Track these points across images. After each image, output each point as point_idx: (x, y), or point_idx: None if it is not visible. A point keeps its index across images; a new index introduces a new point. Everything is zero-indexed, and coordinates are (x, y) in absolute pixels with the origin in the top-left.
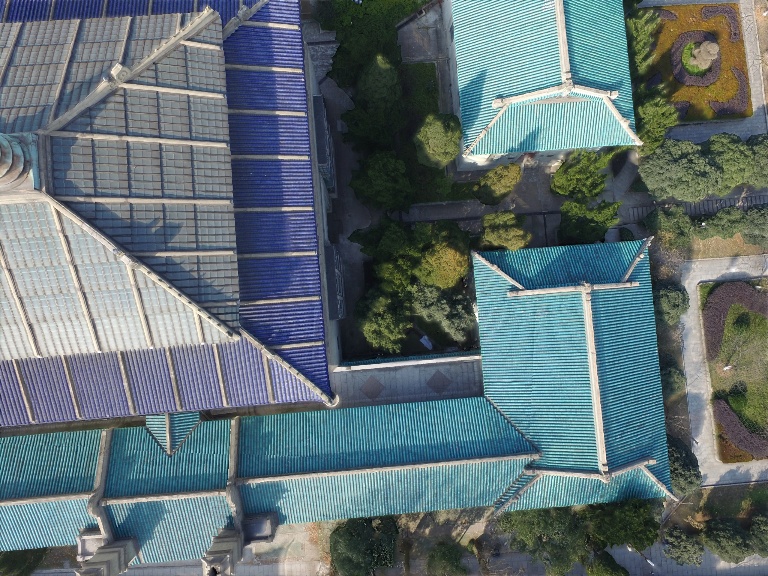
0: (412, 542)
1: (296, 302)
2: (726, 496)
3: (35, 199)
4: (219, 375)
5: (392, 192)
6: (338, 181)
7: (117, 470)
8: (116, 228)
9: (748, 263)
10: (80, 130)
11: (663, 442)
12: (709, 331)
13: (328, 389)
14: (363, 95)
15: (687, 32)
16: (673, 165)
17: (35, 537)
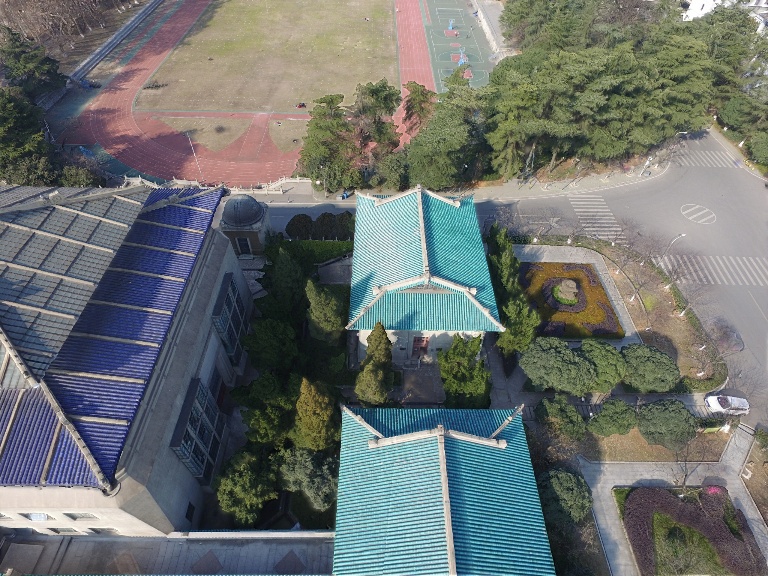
0: None
1: (119, 381)
2: None
3: None
4: (3, 441)
5: (278, 352)
6: (248, 362)
7: None
8: None
9: (663, 470)
10: (3, 220)
11: None
12: (635, 545)
13: (111, 472)
14: (275, 287)
15: (553, 277)
16: (542, 353)
17: None
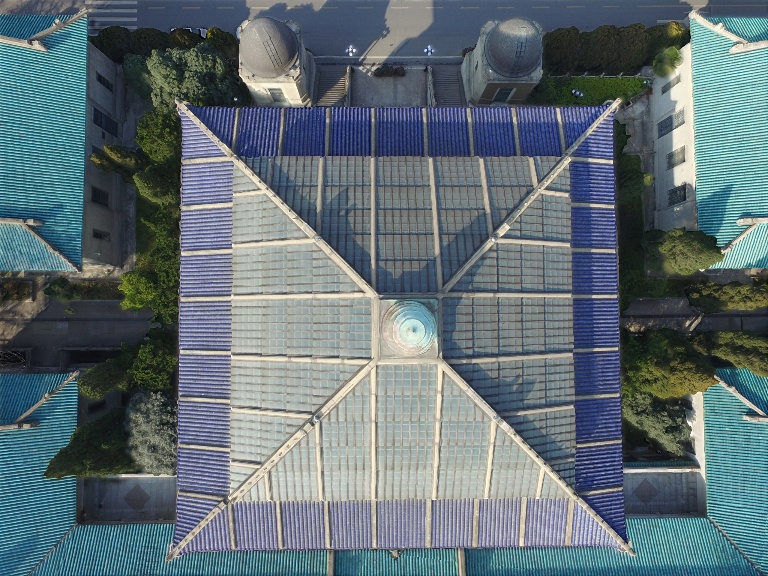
0: None
1: (601, 446)
2: None
3: (427, 362)
4: (523, 517)
5: None
6: None
7: (344, 570)
8: (487, 388)
9: None
10: (464, 289)
11: None
12: None
13: None
14: None
15: None
16: None
17: None
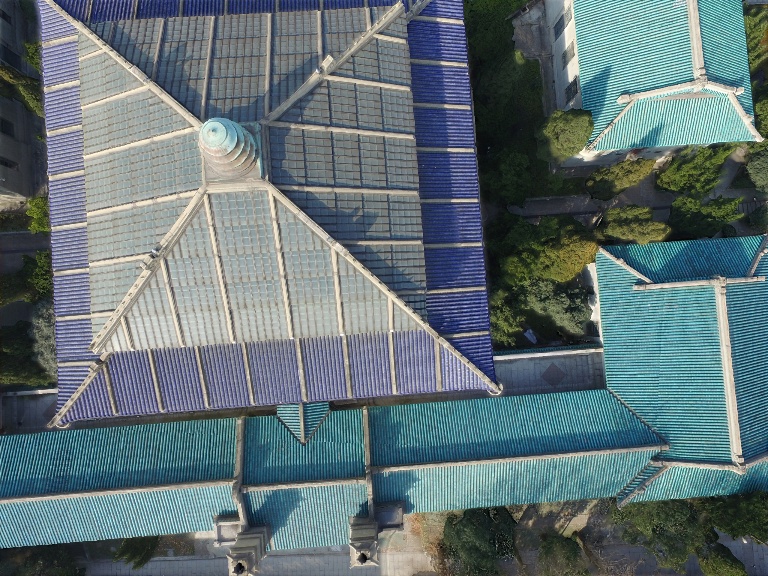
0: (516, 533)
1: (464, 292)
2: None
3: (256, 187)
4: (392, 363)
5: (515, 186)
6: None
7: (253, 458)
8: (324, 217)
9: None
10: (292, 121)
11: None
12: None
13: (494, 378)
14: (484, 90)
15: None
16: None
17: (170, 523)
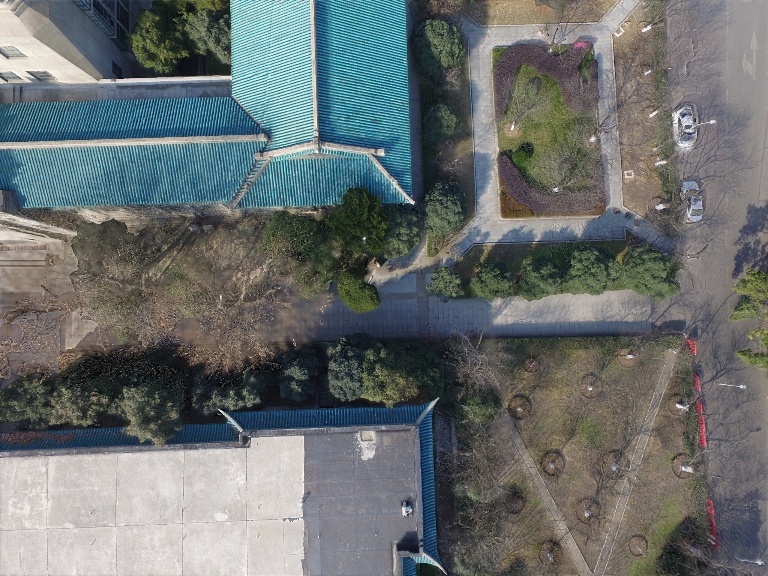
0: None
1: None
2: (507, 254)
3: None
4: None
5: None
6: None
7: None
8: None
9: (544, 32)
10: None
11: (405, 148)
12: (496, 89)
13: None
14: None
15: None
16: None
17: None
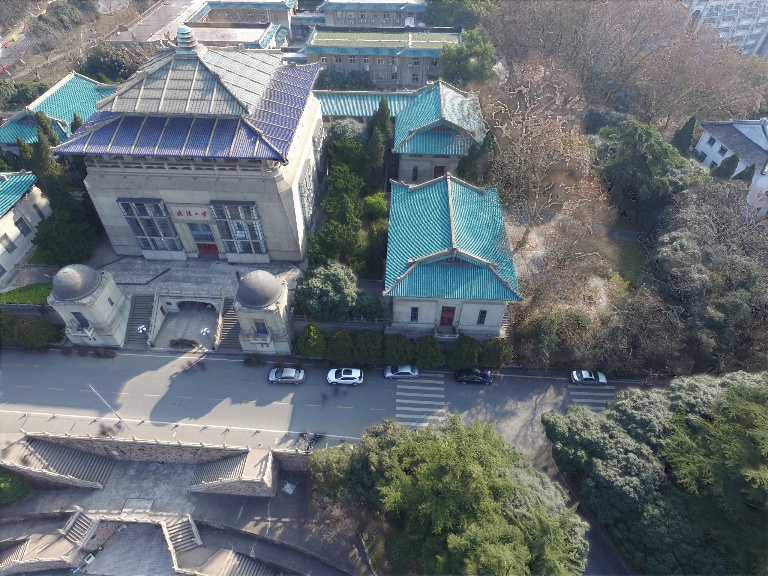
0: None
1: None
2: None
3: None
4: None
5: None
6: None
7: None
8: None
9: None
10: None
11: None
12: None
13: None
14: (80, 206)
15: None
16: None
17: None
